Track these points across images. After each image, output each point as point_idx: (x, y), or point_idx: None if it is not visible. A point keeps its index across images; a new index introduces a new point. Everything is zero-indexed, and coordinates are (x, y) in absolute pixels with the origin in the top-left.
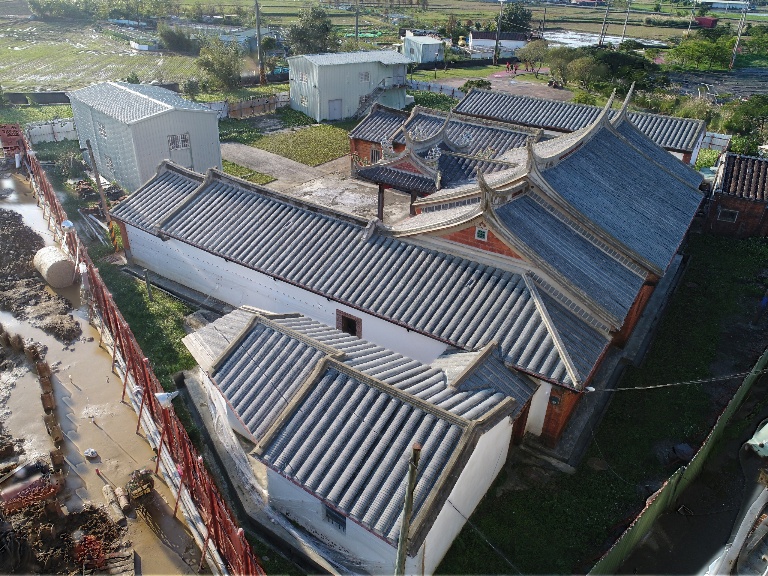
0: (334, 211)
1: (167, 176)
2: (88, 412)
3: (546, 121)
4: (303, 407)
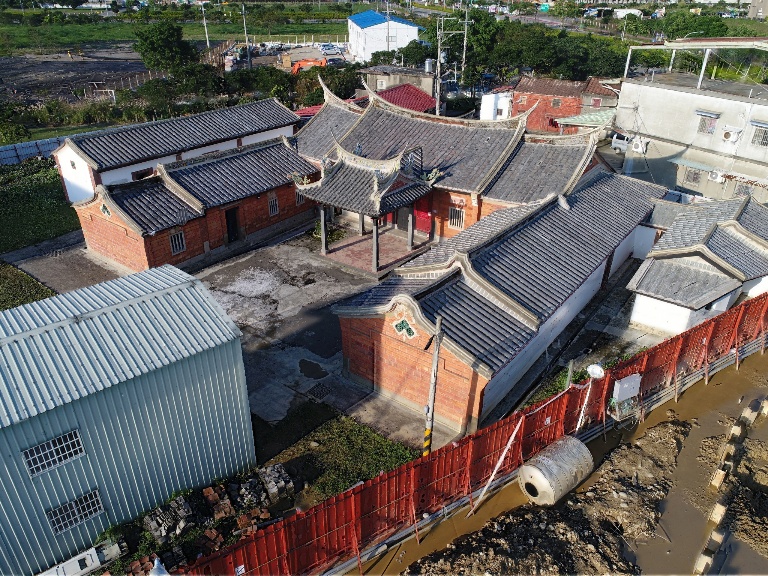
0: (543, 207)
1: (423, 309)
2: (764, 384)
3: (197, 139)
4: (764, 238)
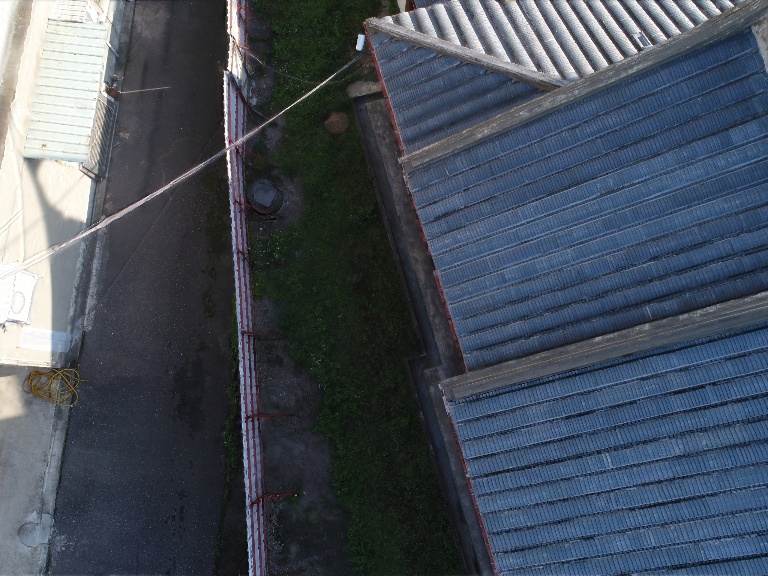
0: None
1: None
2: None
3: None
4: None
